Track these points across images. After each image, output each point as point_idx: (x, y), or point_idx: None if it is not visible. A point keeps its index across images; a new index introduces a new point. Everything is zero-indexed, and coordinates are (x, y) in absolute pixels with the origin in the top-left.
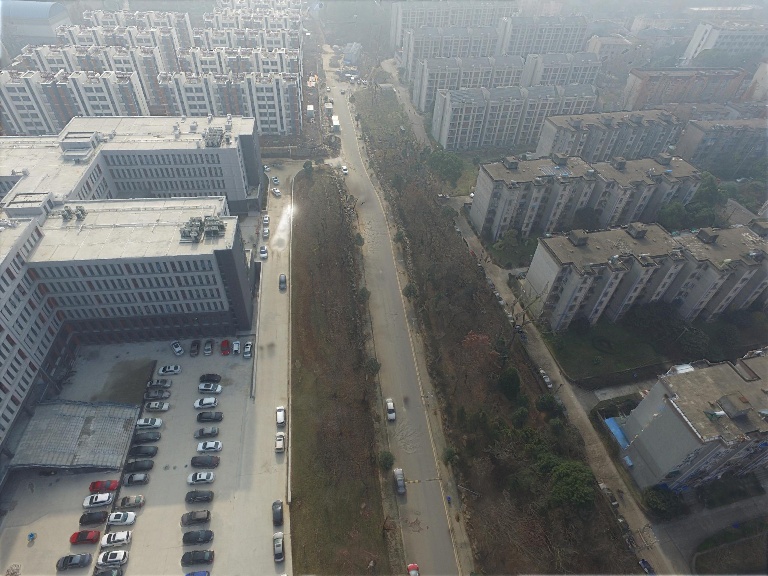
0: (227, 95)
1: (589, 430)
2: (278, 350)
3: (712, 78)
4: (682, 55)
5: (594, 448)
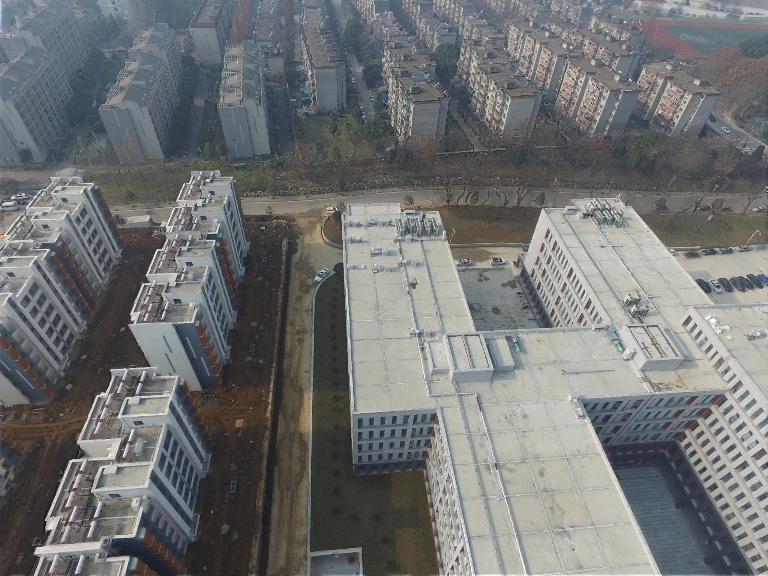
0: (221, 254)
1: None
2: None
3: (222, 7)
4: (100, 12)
5: None
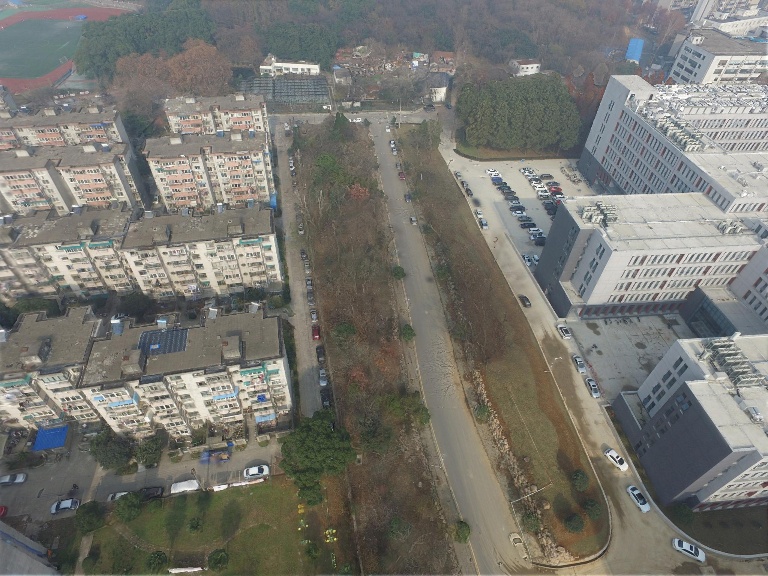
0: None
1: (286, 211)
2: (503, 257)
3: None
4: None
5: (289, 205)
